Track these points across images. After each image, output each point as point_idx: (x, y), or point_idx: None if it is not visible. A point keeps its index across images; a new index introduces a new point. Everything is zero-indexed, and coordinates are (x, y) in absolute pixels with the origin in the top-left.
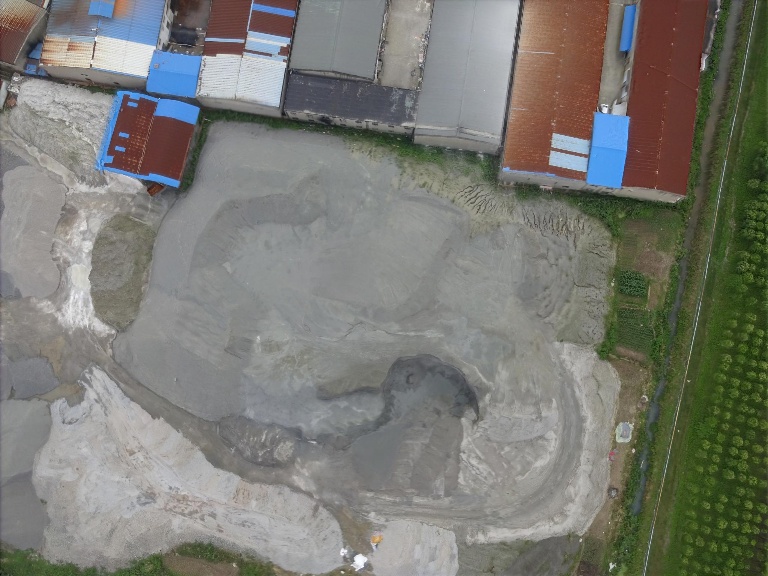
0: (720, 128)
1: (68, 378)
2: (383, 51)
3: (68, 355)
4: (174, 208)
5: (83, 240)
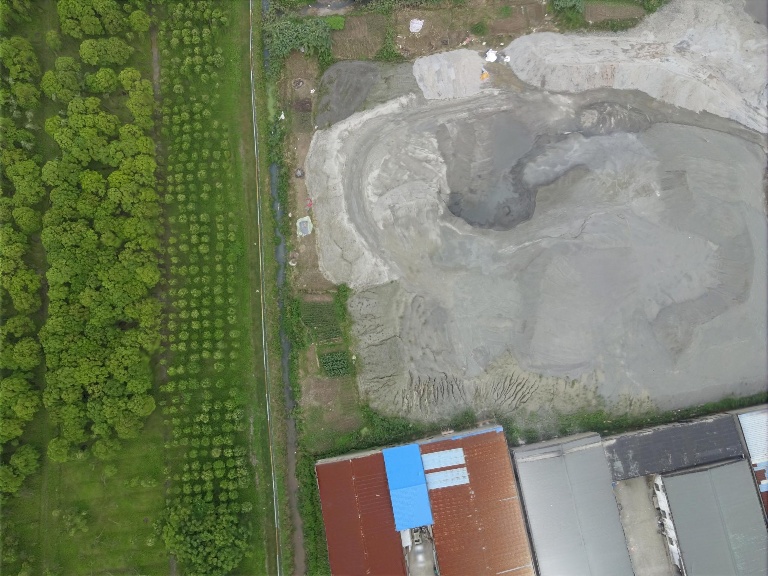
0: (291, 562)
1: None
2: (659, 521)
3: None
4: None
5: None
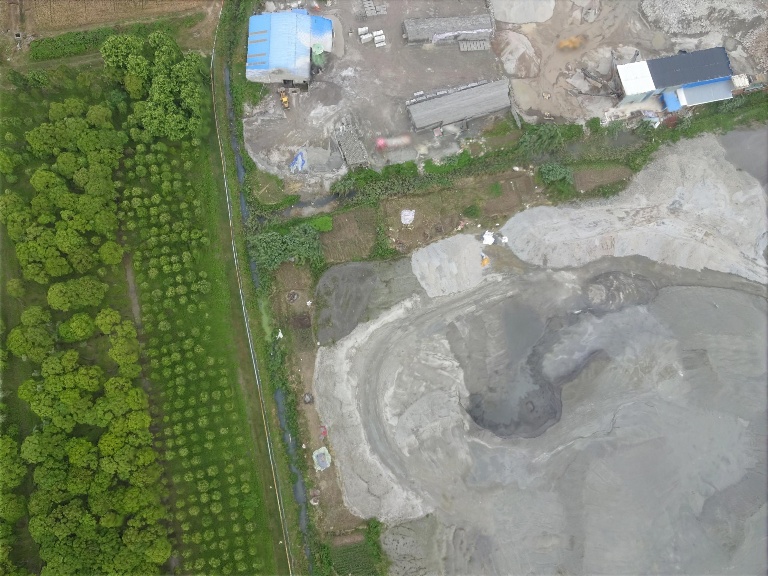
0: None
1: None
2: None
3: None
4: None
5: None
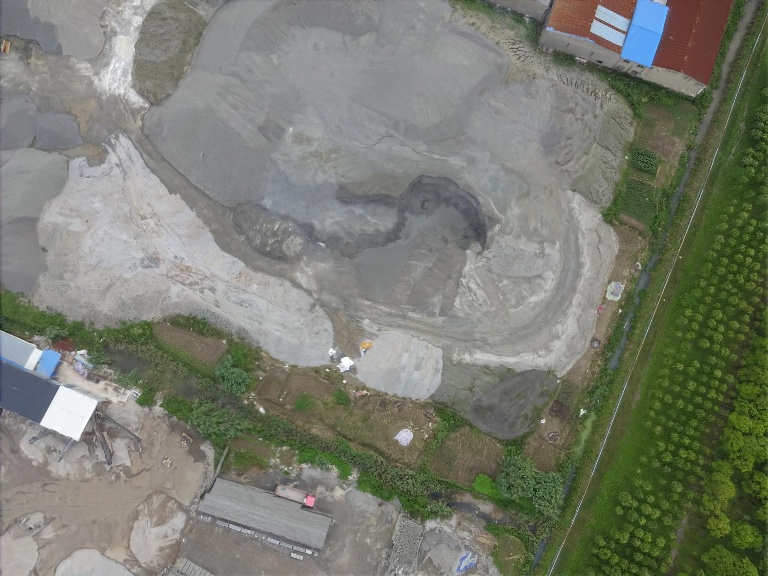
0: (745, 42)
1: (93, 139)
2: None
3: (97, 118)
4: (230, 3)
5: (134, 14)
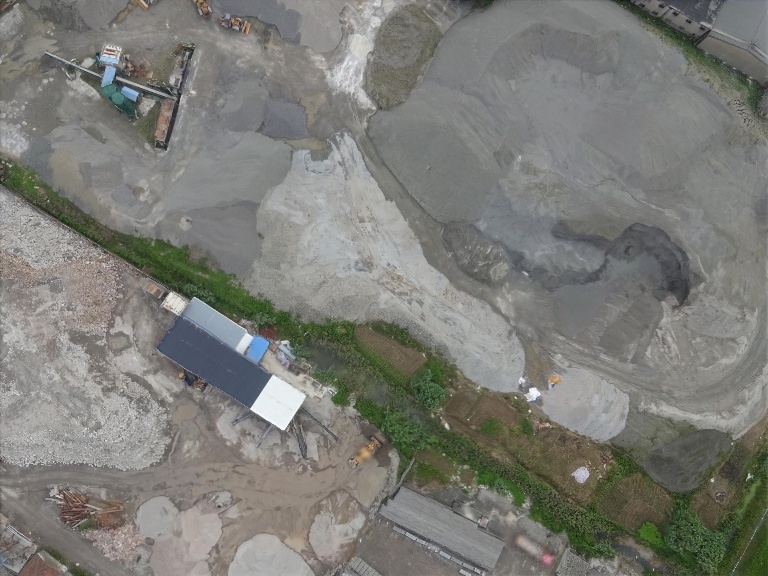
0: None
1: (319, 134)
2: None
3: (325, 113)
4: (468, 18)
5: (373, 15)
